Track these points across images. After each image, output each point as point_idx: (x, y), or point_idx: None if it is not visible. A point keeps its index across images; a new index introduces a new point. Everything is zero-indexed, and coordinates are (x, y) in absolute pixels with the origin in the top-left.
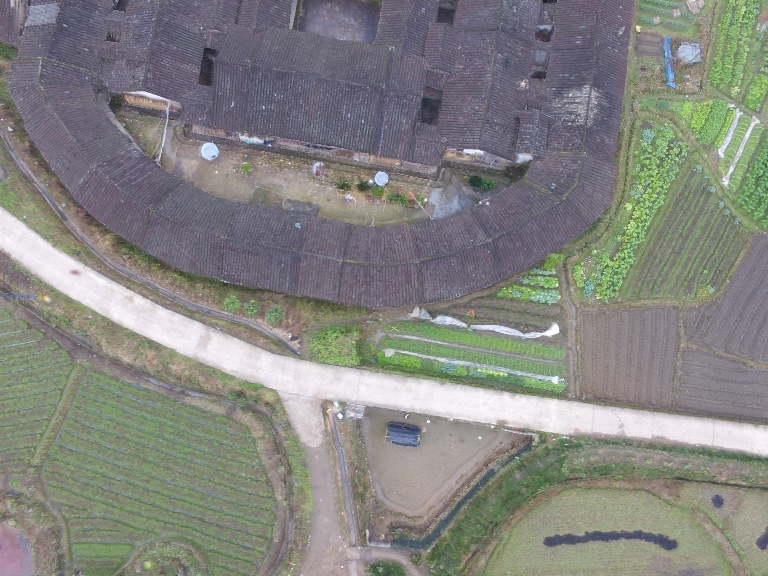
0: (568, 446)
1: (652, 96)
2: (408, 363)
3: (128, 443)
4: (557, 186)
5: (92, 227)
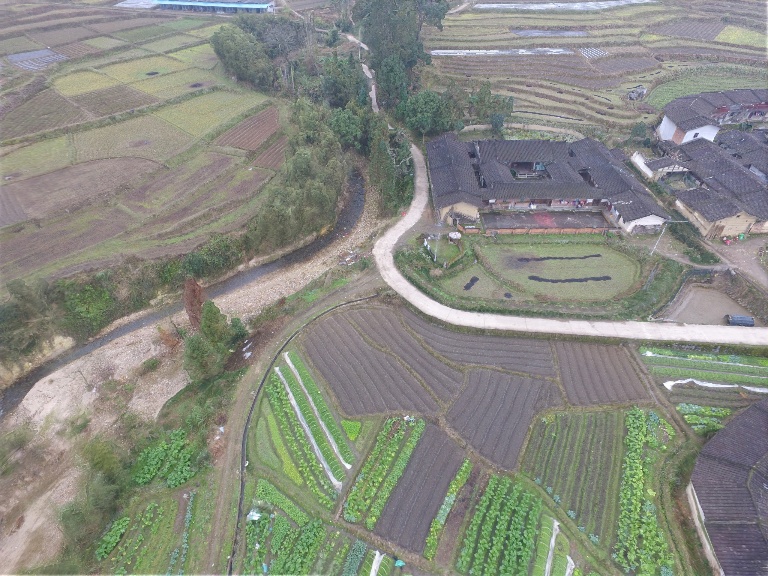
0: (626, 315)
1: None
2: (767, 361)
3: None
4: (763, 485)
5: None
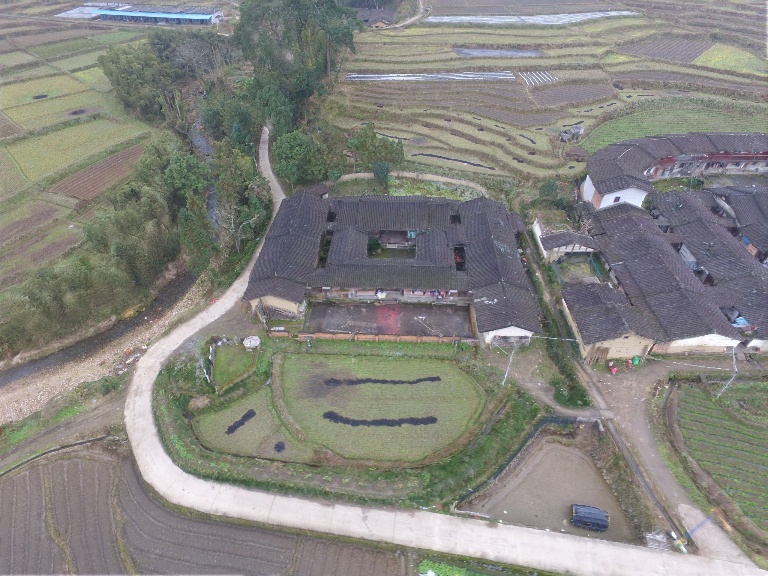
0: (421, 499)
1: None
2: None
3: None
4: None
5: None
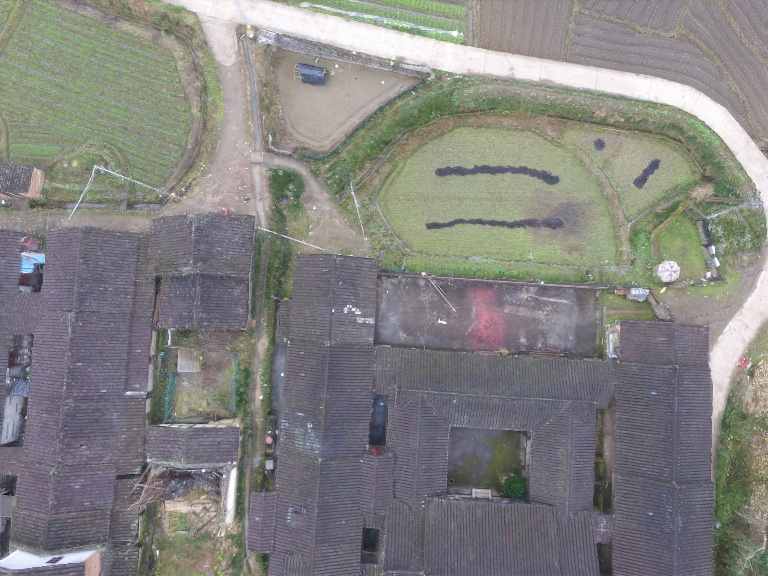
0: None
1: None
2: None
3: (64, 61)
4: None
5: None
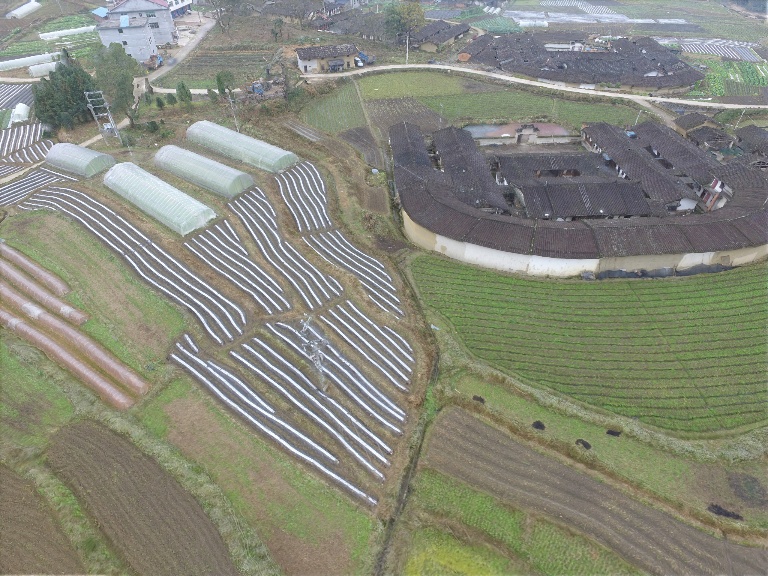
0: None
1: None
2: None
3: None
4: None
5: None
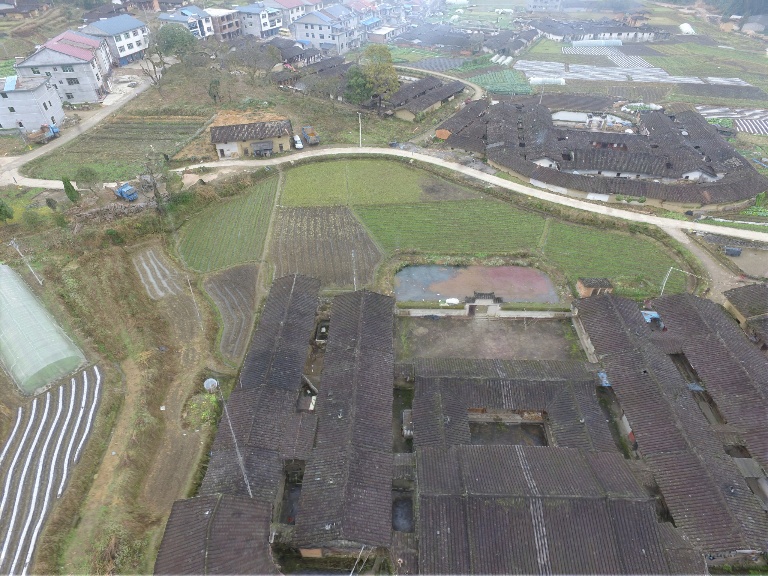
0: None
1: (761, 170)
2: None
3: None
4: None
5: (537, 186)
